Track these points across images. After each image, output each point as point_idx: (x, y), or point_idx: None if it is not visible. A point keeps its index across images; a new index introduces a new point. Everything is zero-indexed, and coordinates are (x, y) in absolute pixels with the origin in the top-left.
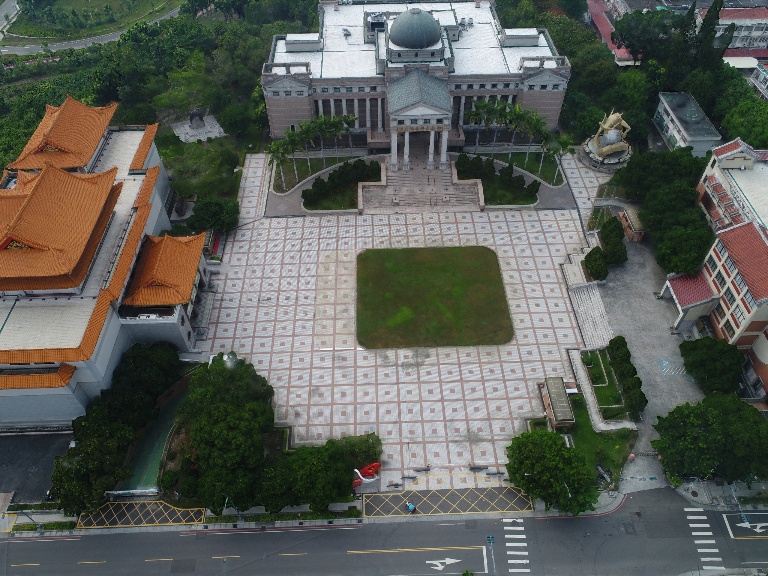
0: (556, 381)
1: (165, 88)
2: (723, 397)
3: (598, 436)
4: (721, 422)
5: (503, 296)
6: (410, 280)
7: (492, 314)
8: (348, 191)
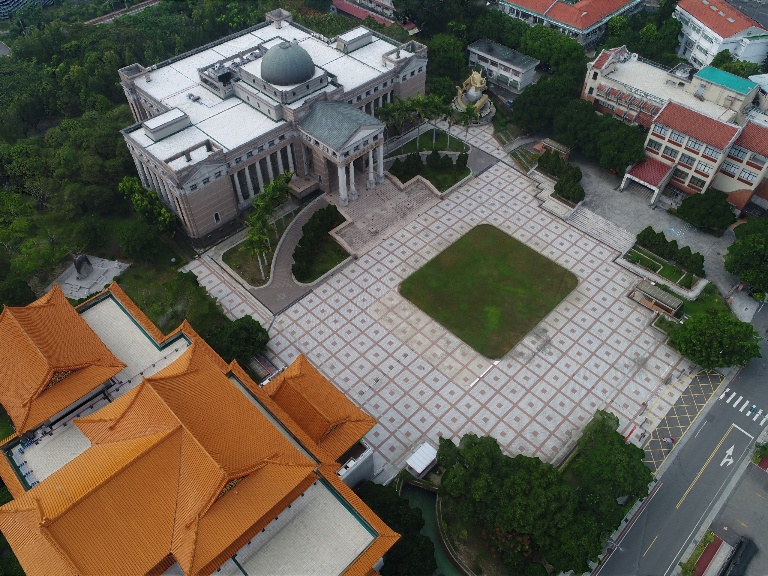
0: (645, 284)
1: (2, 253)
2: (748, 224)
3: (697, 302)
4: (765, 239)
5: (535, 252)
6: (463, 285)
7: (545, 270)
8: (325, 245)
